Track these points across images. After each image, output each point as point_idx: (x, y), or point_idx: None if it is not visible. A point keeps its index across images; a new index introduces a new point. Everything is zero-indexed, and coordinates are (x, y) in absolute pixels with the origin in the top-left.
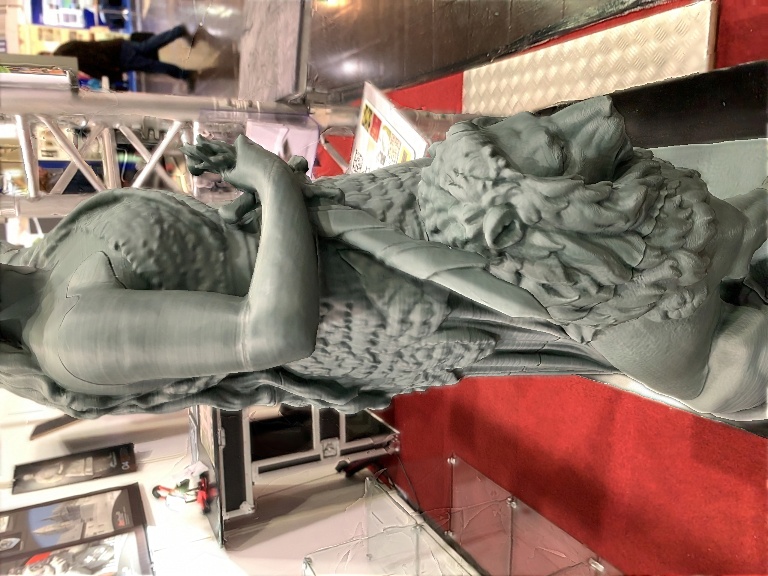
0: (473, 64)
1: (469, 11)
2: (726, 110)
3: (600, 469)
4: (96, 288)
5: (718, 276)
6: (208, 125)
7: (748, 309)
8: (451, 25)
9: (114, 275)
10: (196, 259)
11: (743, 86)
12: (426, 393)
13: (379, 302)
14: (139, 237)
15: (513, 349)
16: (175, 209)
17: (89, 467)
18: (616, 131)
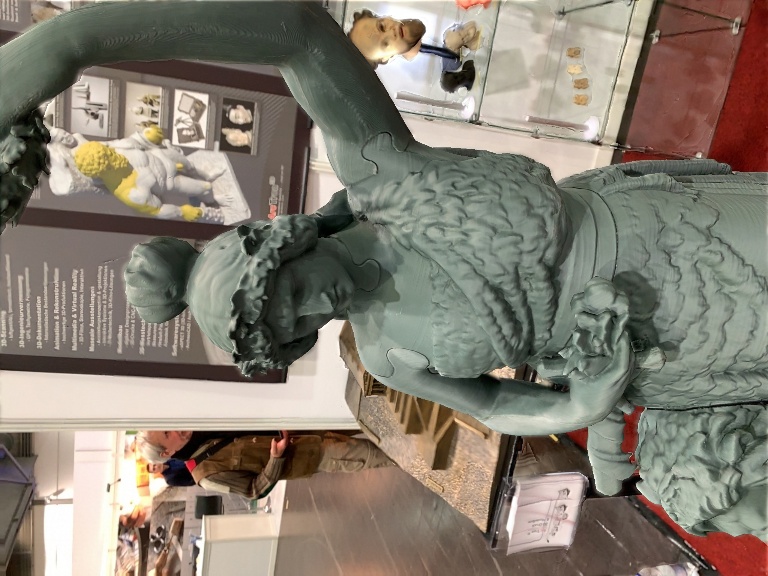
0: None
1: None
2: None
3: None
4: (408, 371)
5: None
6: None
7: None
8: None
9: None
10: None
11: None
12: None
13: None
14: None
15: None
16: None
17: None
18: None
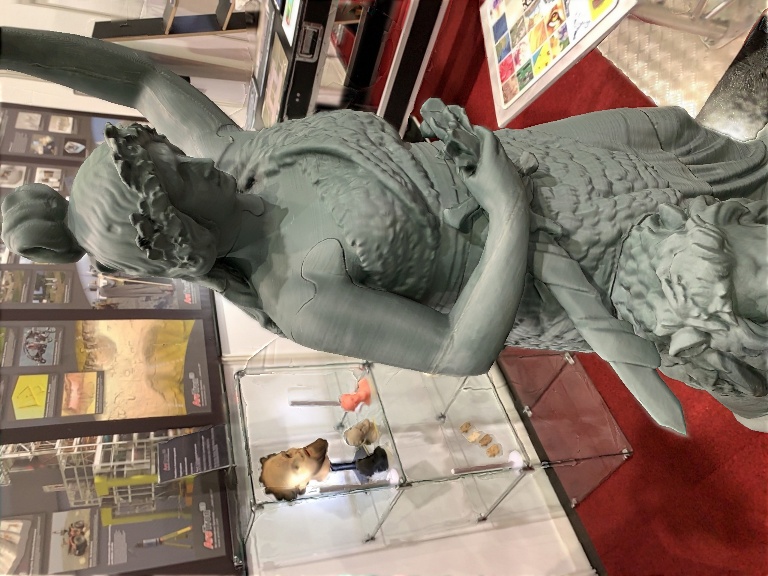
0: None
1: None
2: None
3: None
4: (330, 281)
5: None
6: None
7: None
8: None
9: (345, 268)
10: (412, 258)
11: None
12: None
13: (547, 323)
14: (375, 240)
15: None
16: (408, 207)
17: None
18: None
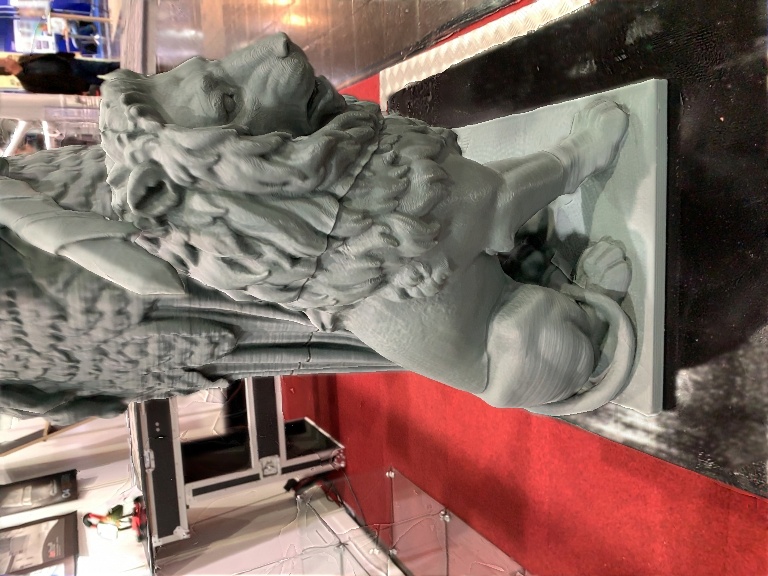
0: (389, 63)
1: (383, 10)
2: (540, 75)
3: (521, 477)
4: None
5: (465, 246)
6: (76, 127)
7: (526, 286)
8: (369, 25)
9: None
10: None
11: (552, 47)
12: (365, 405)
13: (51, 289)
14: None
15: (271, 343)
16: None
17: (27, 497)
18: (294, 74)
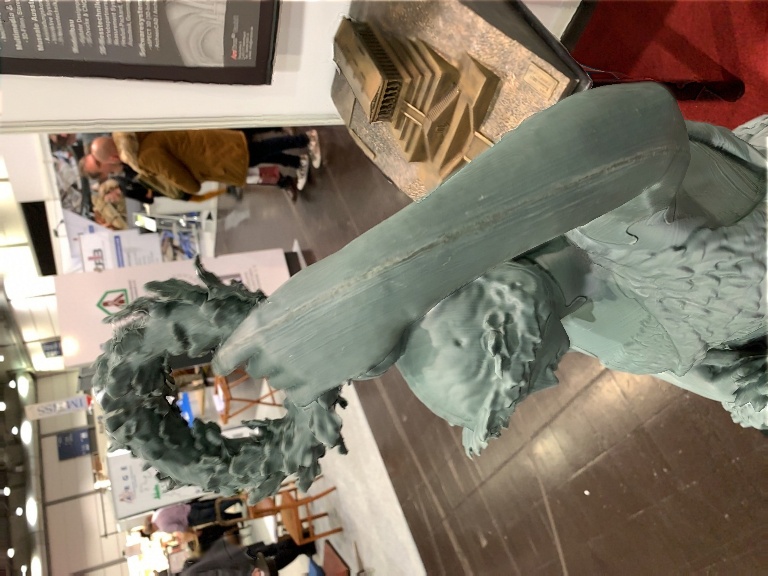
0: None
1: None
2: None
3: None
4: None
5: None
6: None
7: None
8: None
9: None
10: None
11: None
12: None
13: None
14: None
15: None
16: None
17: None
18: None
